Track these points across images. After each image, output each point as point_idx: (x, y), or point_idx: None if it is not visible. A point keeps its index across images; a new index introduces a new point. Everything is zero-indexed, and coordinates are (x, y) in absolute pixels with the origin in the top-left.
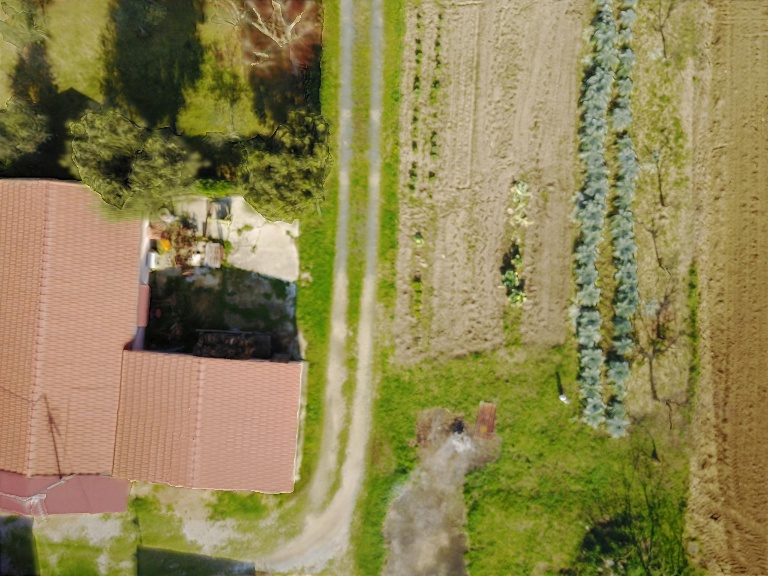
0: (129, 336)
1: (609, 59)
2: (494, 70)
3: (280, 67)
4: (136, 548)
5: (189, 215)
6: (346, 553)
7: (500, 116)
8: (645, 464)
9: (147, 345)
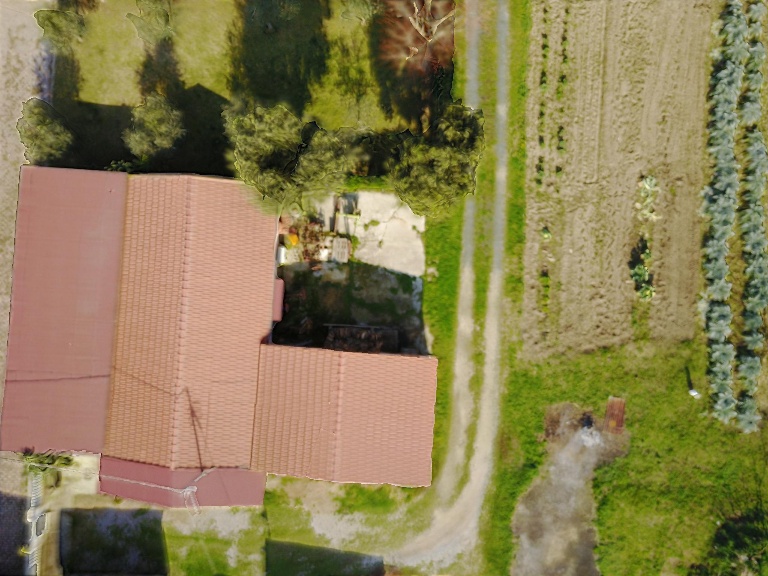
0: (265, 330)
1: (740, 53)
2: (621, 64)
3: (407, 62)
4: (264, 541)
5: (316, 210)
6: (475, 547)
7: (628, 110)
8: None
9: (275, 339)
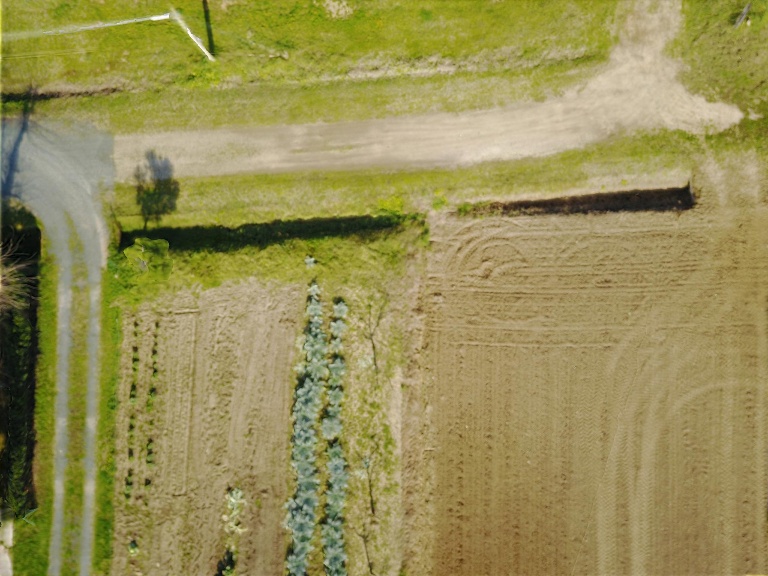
0: None
1: (318, 370)
2: (210, 377)
3: None
4: None
5: None
6: None
7: (215, 423)
8: None
9: None
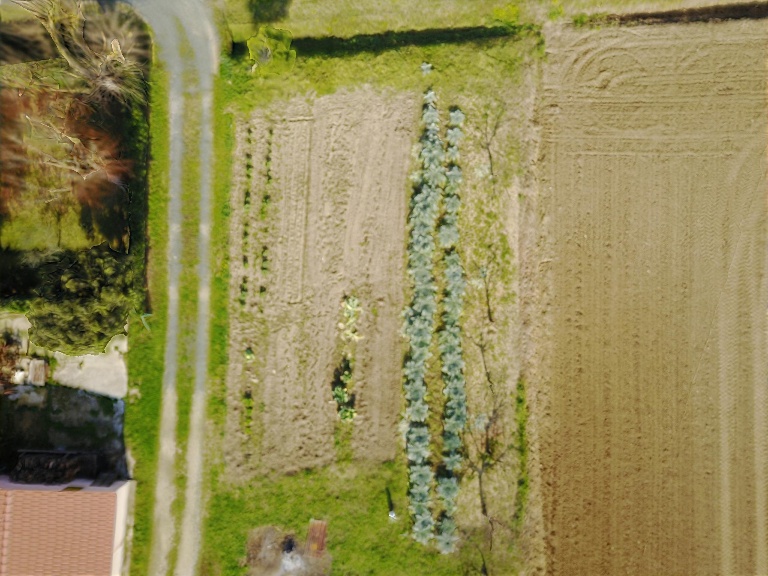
0: None
1: (436, 177)
2: (325, 185)
3: None
4: None
5: (13, 332)
6: None
7: (331, 231)
8: None
9: None
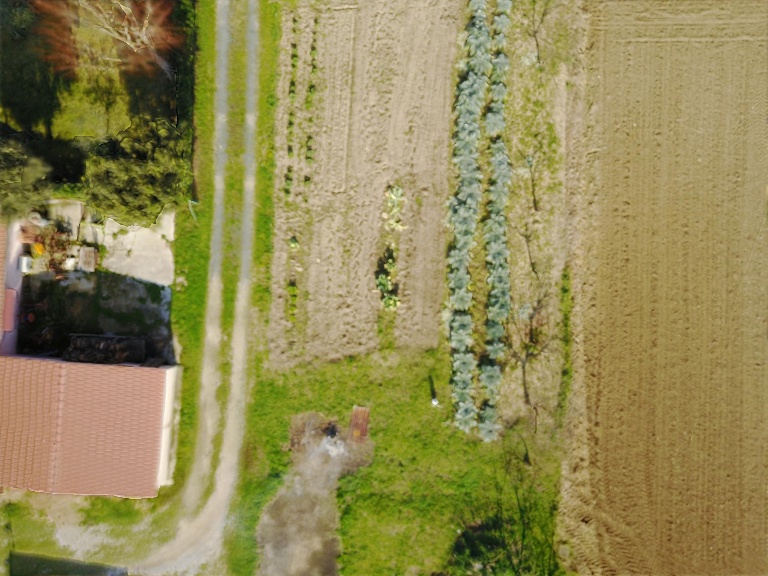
0: None
1: (482, 64)
2: (369, 75)
3: (155, 71)
4: (9, 553)
5: (64, 219)
6: (219, 557)
7: (375, 120)
8: (517, 468)
9: (20, 349)
